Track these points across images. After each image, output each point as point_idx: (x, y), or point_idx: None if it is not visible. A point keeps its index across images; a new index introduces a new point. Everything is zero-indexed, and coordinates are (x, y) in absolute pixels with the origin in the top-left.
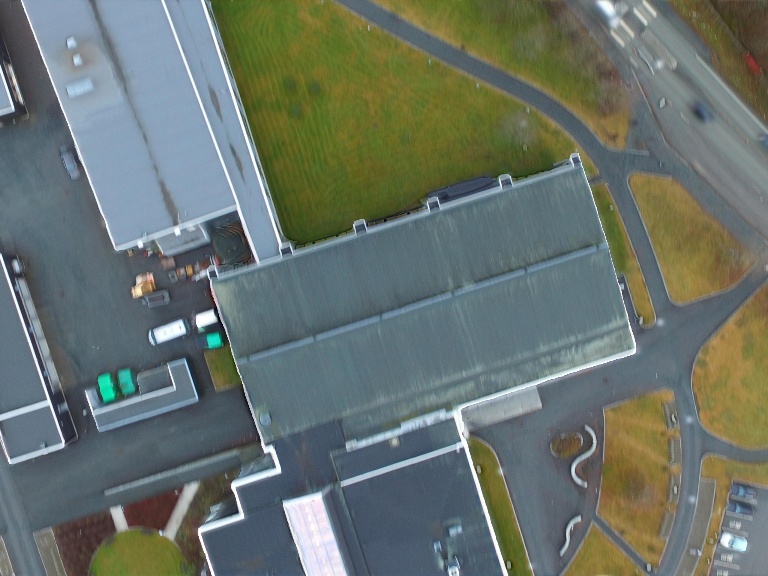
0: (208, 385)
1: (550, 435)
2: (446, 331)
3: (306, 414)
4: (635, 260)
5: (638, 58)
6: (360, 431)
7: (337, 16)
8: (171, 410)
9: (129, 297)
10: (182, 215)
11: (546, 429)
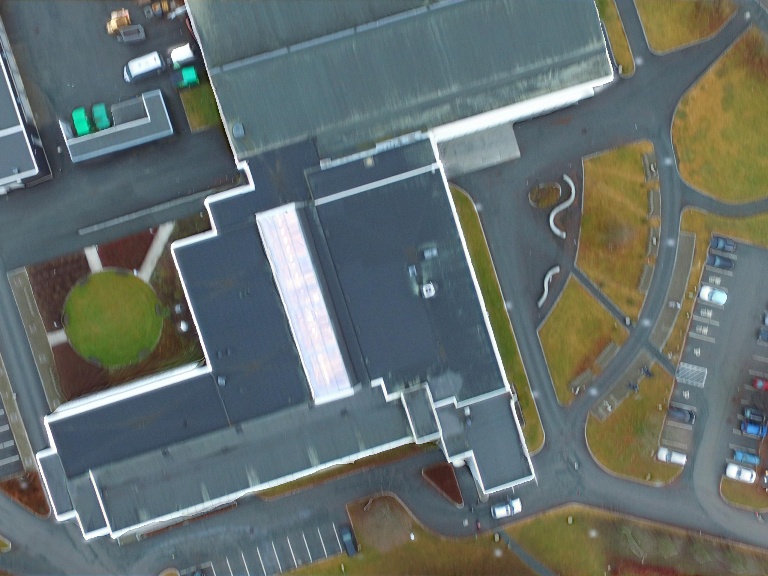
0: (184, 126)
1: (528, 185)
2: (421, 48)
3: (280, 130)
4: (614, 8)
5: None
6: (335, 151)
7: None
8: (145, 142)
9: (104, 33)
10: None
11: (524, 179)
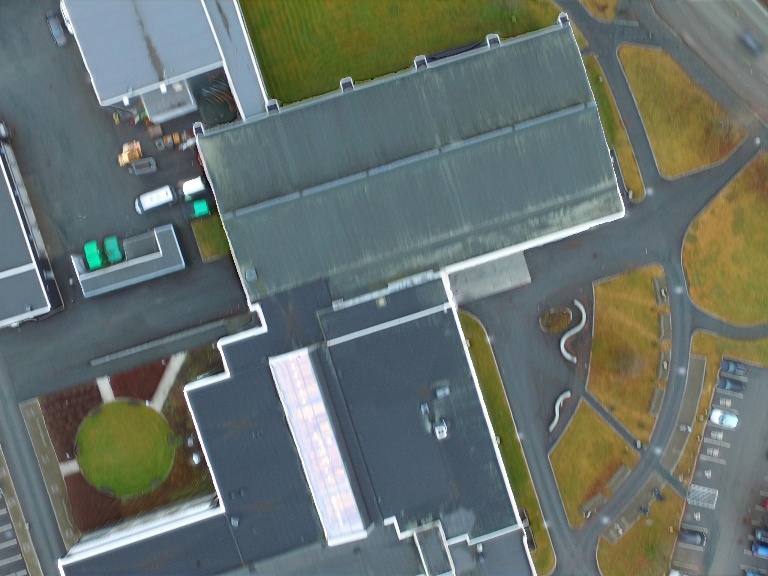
0: (195, 256)
1: (539, 310)
2: (433, 189)
3: (292, 272)
4: (625, 133)
5: None
6: (347, 291)
7: None
8: (157, 276)
9: (116, 165)
10: (168, 71)
11: (535, 304)
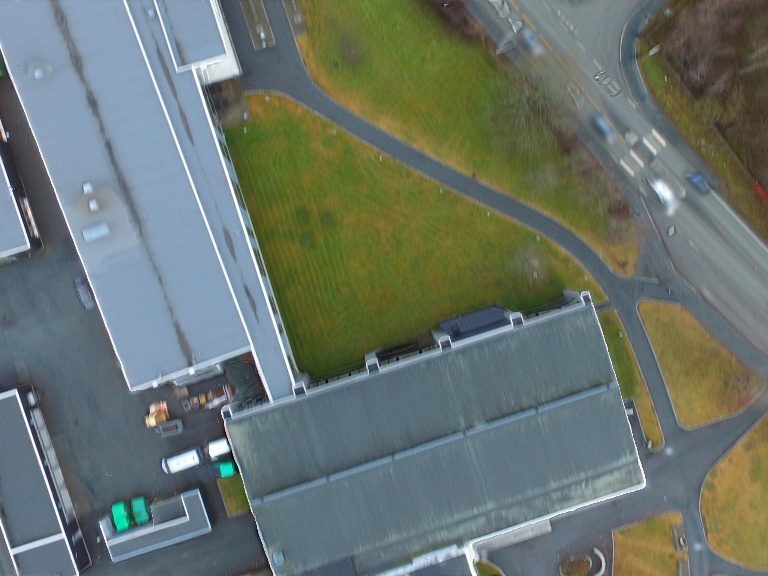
0: (221, 511)
1: (559, 558)
2: (458, 470)
3: (319, 552)
4: (644, 385)
5: (647, 187)
6: (372, 567)
7: (349, 146)
8: (184, 540)
9: (143, 425)
10: (196, 356)
11: (555, 552)
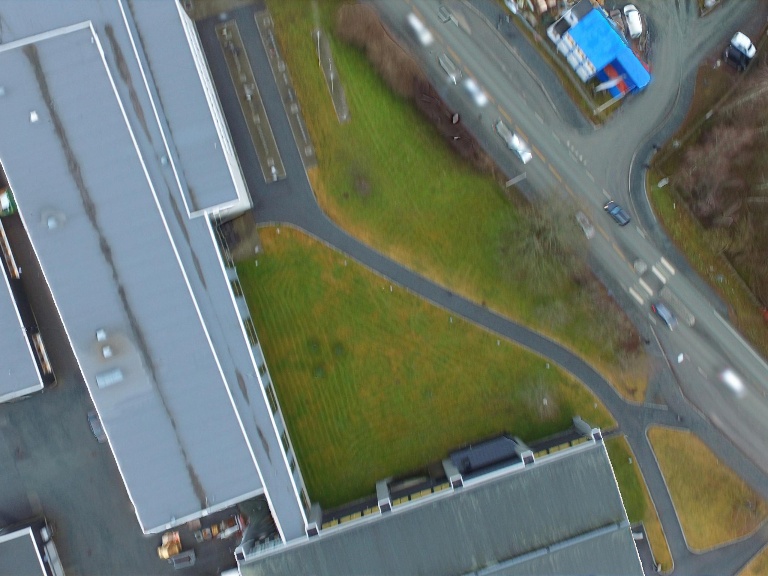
0: None
1: None
2: None
3: None
4: (653, 509)
5: (656, 315)
6: None
7: (360, 276)
8: None
9: (155, 556)
10: (210, 498)
11: None
